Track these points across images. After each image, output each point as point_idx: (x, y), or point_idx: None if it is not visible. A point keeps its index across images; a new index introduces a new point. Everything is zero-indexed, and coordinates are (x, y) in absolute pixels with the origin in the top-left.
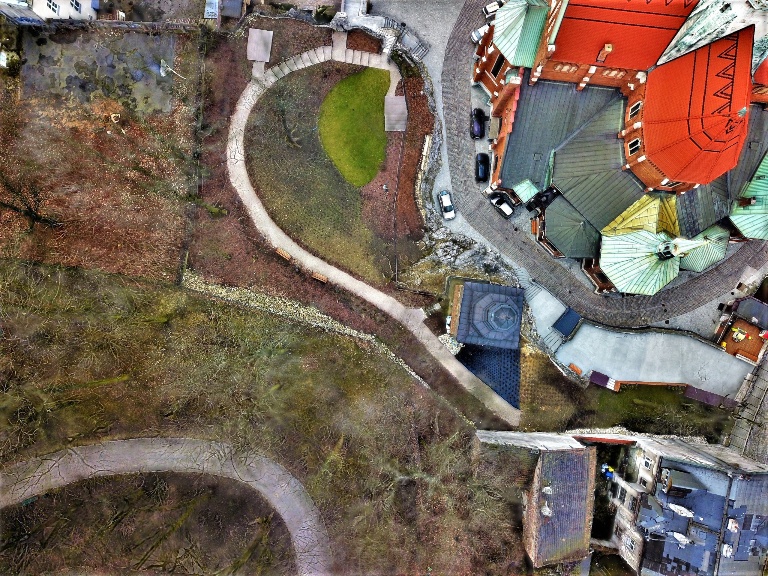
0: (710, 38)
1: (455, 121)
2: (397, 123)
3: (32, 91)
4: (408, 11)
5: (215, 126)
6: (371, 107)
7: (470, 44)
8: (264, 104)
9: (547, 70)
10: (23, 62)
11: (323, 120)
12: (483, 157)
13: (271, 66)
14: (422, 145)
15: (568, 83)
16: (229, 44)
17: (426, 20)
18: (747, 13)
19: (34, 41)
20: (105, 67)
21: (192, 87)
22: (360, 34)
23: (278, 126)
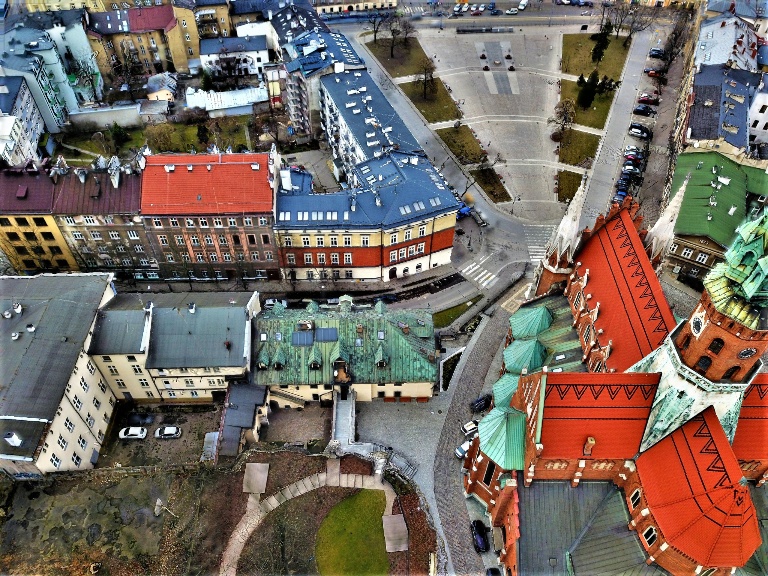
0: (679, 422)
1: (456, 536)
2: (398, 543)
3: (9, 548)
4: (393, 437)
5: (205, 565)
6: (369, 528)
7: (456, 460)
8: (259, 536)
9: (539, 469)
10: (8, 518)
11: (320, 548)
12: (494, 572)
13: (267, 496)
14: (428, 564)
15: (562, 481)
16: (226, 479)
17: (411, 443)
18: (702, 396)
19: (26, 496)
20: (95, 514)
21: (184, 525)
22: (352, 459)
23: (273, 559)
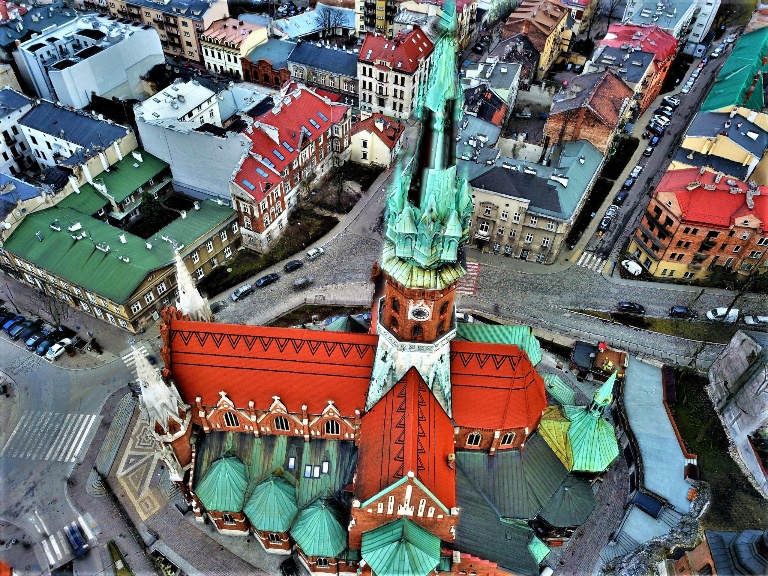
0: None
1: None
2: None
3: None
4: None
5: None
6: None
7: None
8: None
9: None
10: None
11: None
12: None
13: None
14: None
15: None
16: None
17: None
18: None
19: None
20: None
21: None
22: None
23: None
